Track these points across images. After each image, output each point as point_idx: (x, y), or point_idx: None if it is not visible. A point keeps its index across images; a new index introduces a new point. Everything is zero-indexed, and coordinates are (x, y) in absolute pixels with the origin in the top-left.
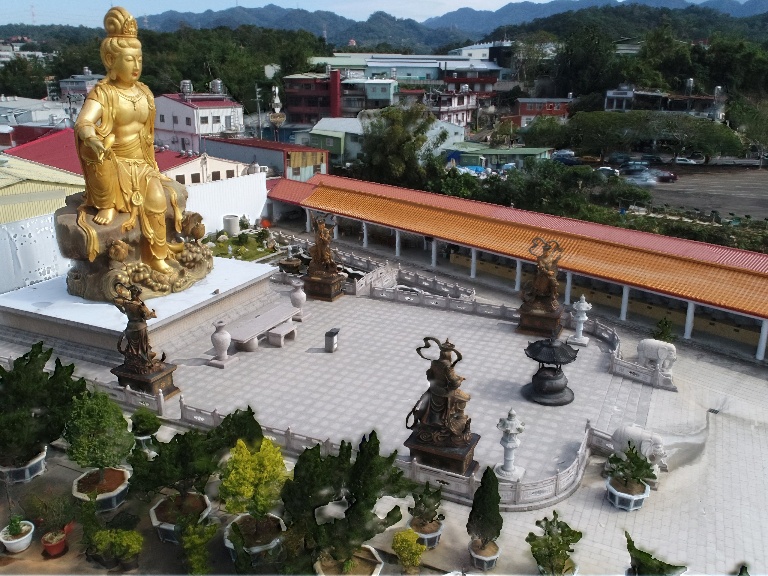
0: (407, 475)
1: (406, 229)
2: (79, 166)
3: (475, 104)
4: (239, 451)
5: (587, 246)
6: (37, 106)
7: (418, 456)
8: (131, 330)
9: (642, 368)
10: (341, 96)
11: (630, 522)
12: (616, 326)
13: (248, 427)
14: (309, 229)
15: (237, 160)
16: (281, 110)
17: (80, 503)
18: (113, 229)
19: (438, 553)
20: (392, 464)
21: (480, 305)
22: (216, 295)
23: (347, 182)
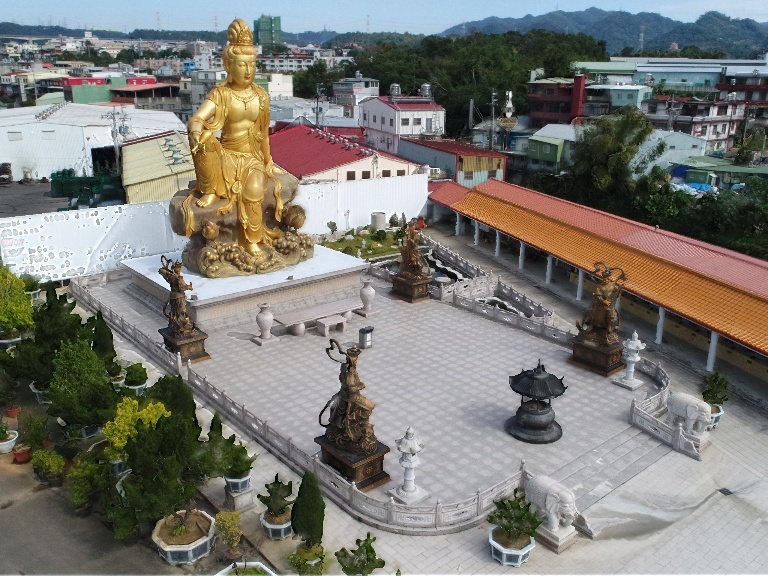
0: (312, 470)
1: (525, 241)
2: (284, 158)
3: (743, 114)
4: (124, 406)
5: (688, 280)
6: (290, 105)
7: (326, 454)
8: (171, 298)
9: (663, 424)
10: (584, 102)
11: (493, 575)
12: (693, 375)
13: (175, 392)
14: (458, 233)
15: (423, 161)
16: (513, 115)
17: (34, 424)
18: (209, 212)
19: (279, 545)
20: (303, 456)
21: (548, 328)
22: (289, 281)
23: (512, 189)
